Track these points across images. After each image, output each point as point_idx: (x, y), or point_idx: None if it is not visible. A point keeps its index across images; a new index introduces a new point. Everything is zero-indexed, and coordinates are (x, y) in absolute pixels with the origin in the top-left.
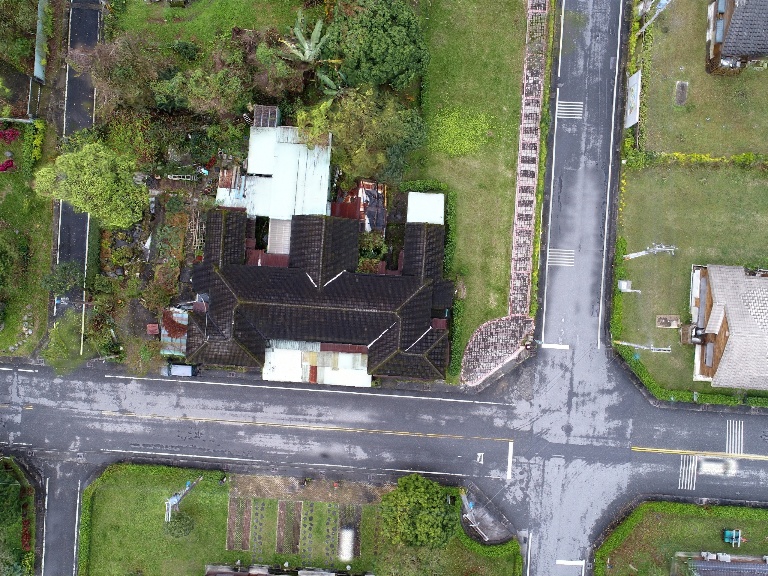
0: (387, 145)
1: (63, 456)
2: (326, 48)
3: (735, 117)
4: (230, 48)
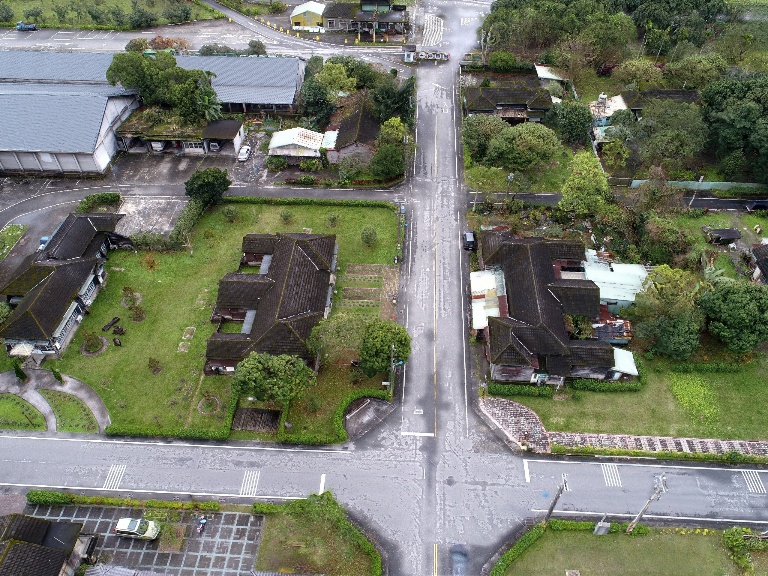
0: (666, 315)
1: (408, 196)
2: (719, 284)
3: None
4: None
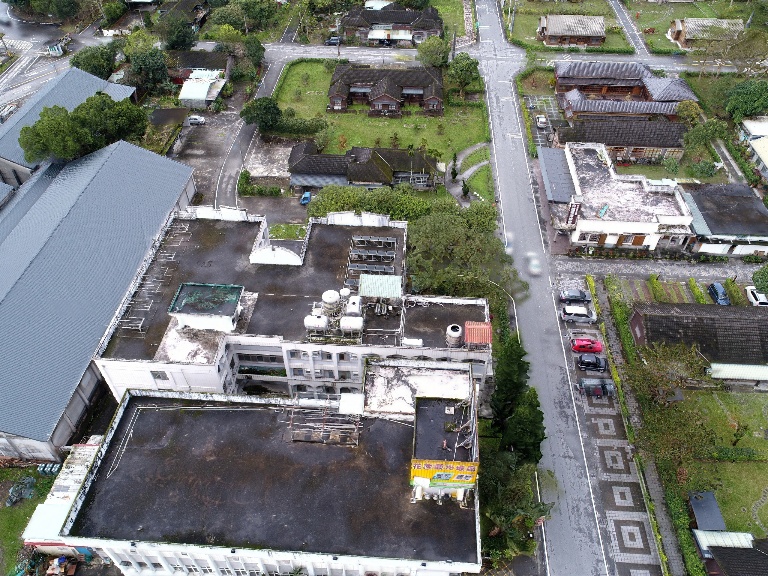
0: None
1: (279, 60)
2: None
3: (541, 7)
4: None
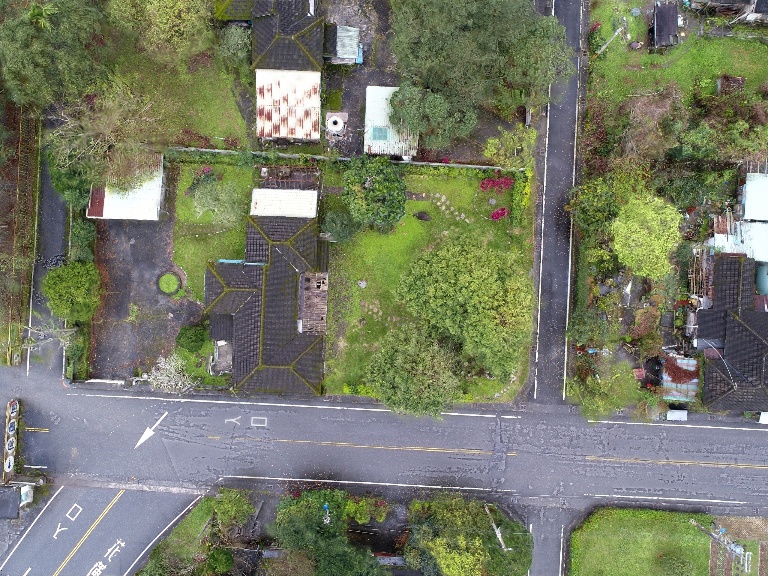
0: None
1: (546, 502)
2: None
3: None
4: (763, 99)
